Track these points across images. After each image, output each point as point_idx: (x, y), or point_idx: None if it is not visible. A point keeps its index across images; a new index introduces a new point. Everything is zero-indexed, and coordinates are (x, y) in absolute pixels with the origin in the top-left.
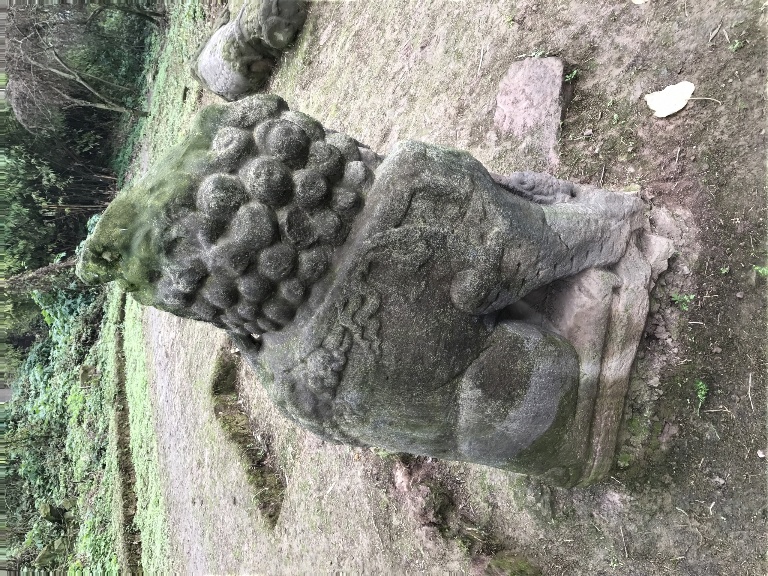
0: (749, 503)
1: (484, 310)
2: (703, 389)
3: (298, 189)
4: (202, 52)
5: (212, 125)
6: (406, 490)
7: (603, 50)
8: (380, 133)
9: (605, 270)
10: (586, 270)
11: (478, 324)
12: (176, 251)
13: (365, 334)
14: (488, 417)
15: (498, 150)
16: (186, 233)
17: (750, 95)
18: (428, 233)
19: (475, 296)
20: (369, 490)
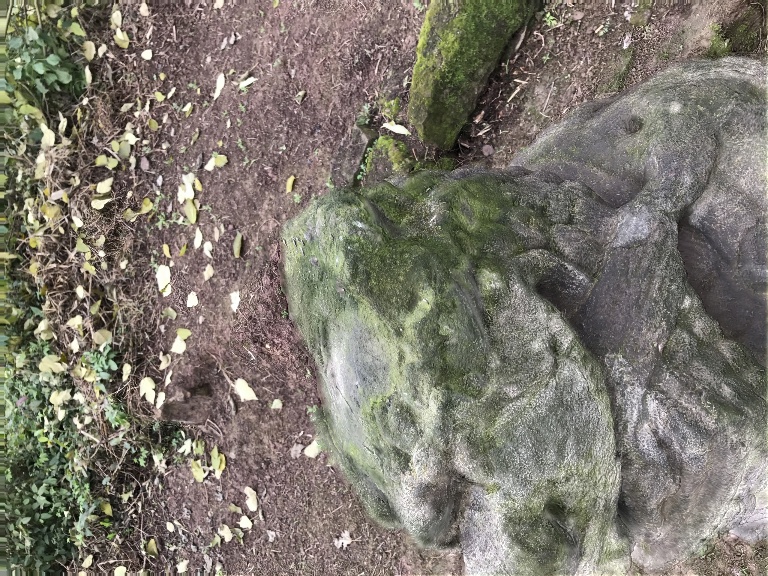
0: None
1: None
2: None
3: None
4: None
5: None
6: None
7: None
8: None
9: None
10: None
11: None
12: None
13: None
14: None
15: None
16: None
17: None
18: None
19: None
20: None
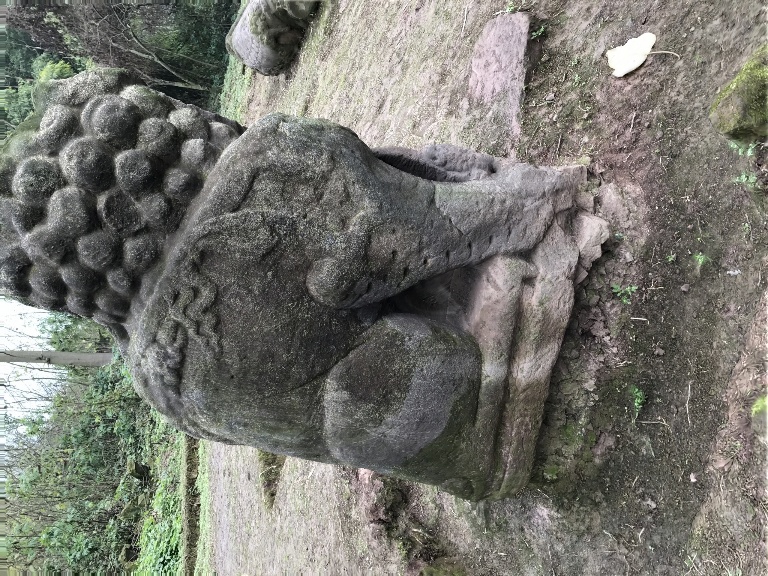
0: (678, 534)
1: (353, 303)
2: (639, 397)
3: (117, 171)
4: (236, 26)
5: (43, 104)
6: None
7: (575, 1)
8: (376, 104)
9: (515, 258)
10: (493, 257)
11: (348, 319)
12: None
13: (201, 329)
14: (359, 422)
15: (468, 120)
16: (2, 220)
17: (710, 46)
18: (272, 218)
19: (334, 288)
20: (337, 479)
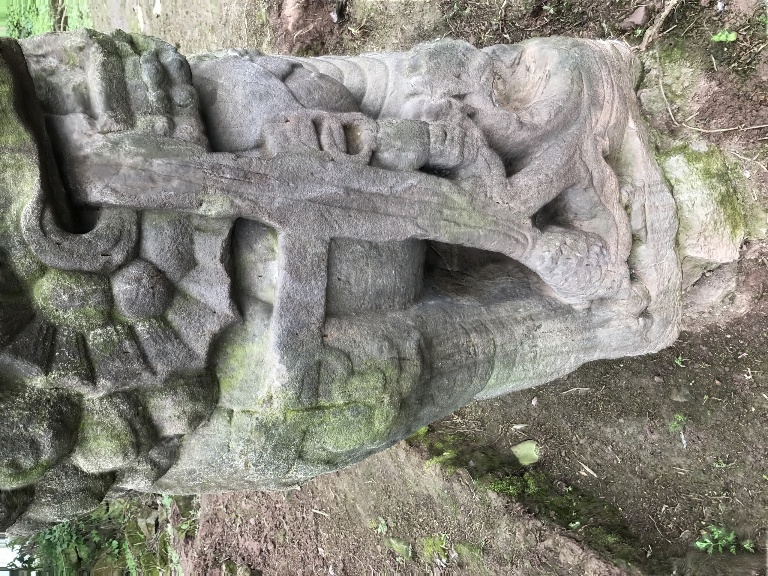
0: None
1: None
2: None
3: None
4: None
5: None
6: (290, 29)
7: None
8: None
9: None
10: None
11: None
12: None
13: None
14: None
15: None
16: None
17: None
18: None
19: None
20: None
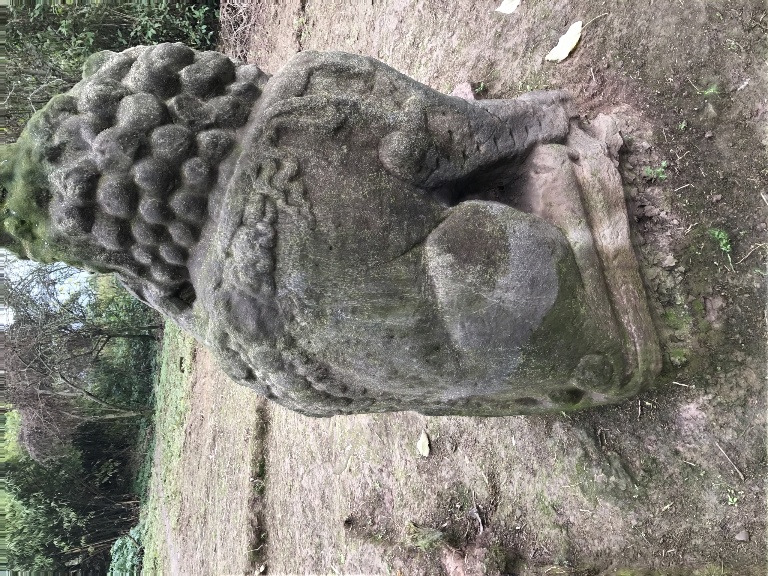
0: None
1: (427, 178)
2: (723, 238)
3: (183, 75)
4: None
5: (96, 66)
6: (463, 575)
7: (500, 60)
8: None
9: None
10: (534, 150)
11: (426, 196)
12: (61, 159)
13: (289, 200)
14: (472, 286)
15: None
16: (68, 135)
17: None
18: (335, 100)
19: (408, 155)
20: None
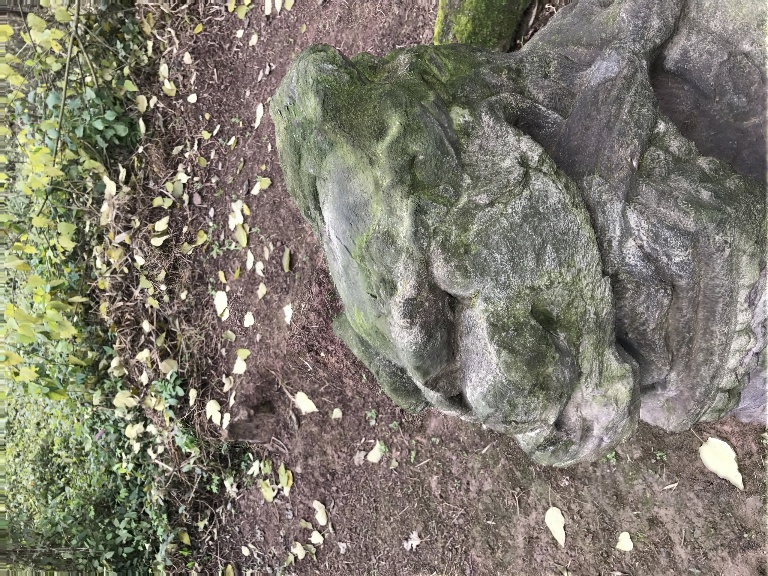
0: None
1: None
2: None
3: None
4: None
5: None
6: None
7: None
8: None
9: None
10: None
11: None
12: None
13: None
14: None
15: None
16: None
17: None
18: None
19: None
20: None
